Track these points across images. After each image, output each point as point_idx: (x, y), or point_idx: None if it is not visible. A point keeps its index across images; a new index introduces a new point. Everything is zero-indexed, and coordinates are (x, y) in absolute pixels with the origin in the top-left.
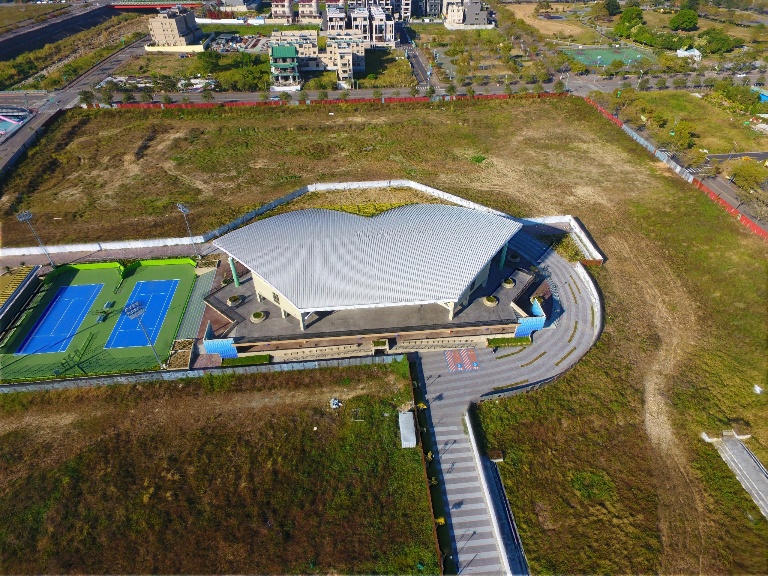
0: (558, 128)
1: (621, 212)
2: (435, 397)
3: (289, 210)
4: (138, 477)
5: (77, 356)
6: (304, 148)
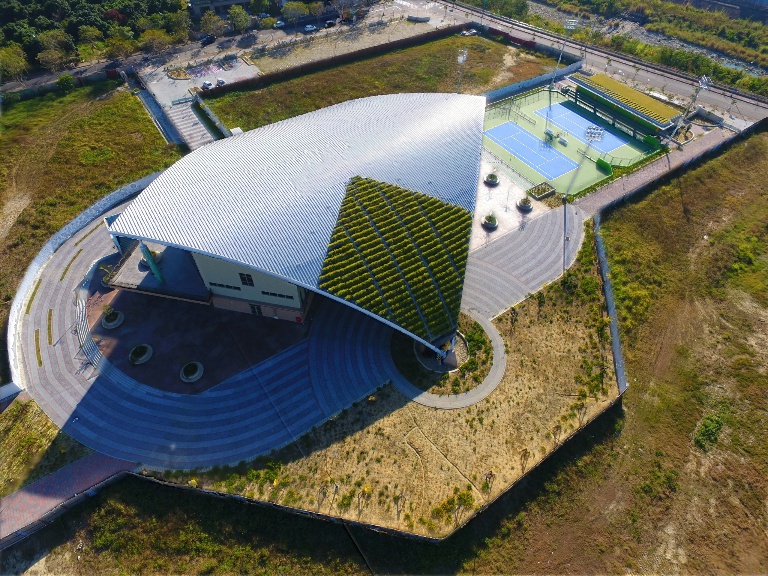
0: None
1: None
2: None
3: (579, 319)
4: (392, 88)
5: None
6: None
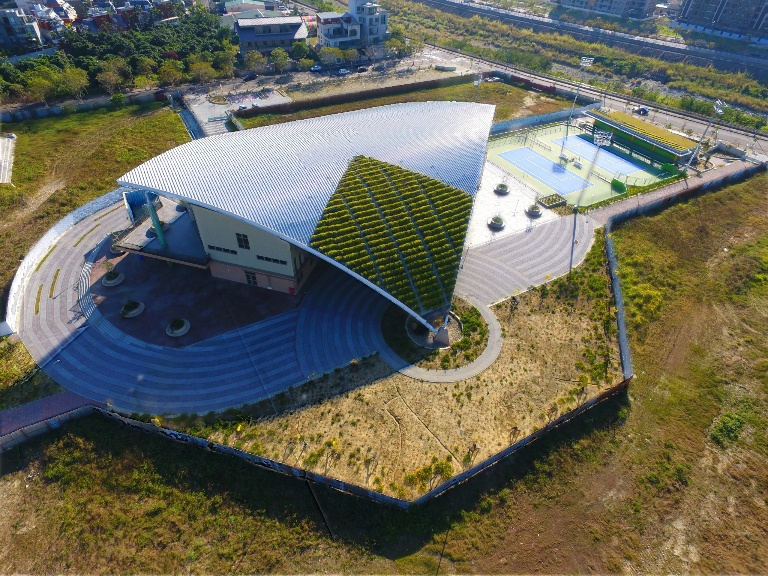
0: None
1: None
2: None
3: (584, 312)
4: None
5: None
6: None
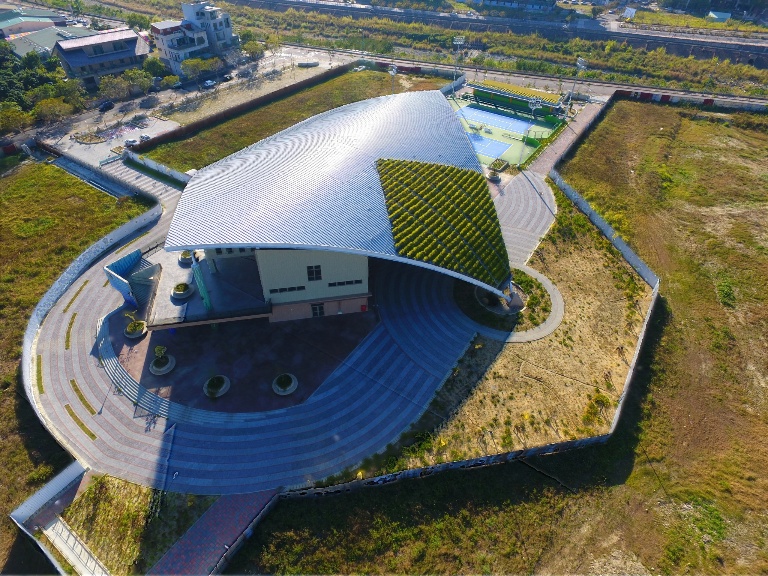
0: None
1: None
2: None
3: (589, 245)
4: None
5: None
6: None
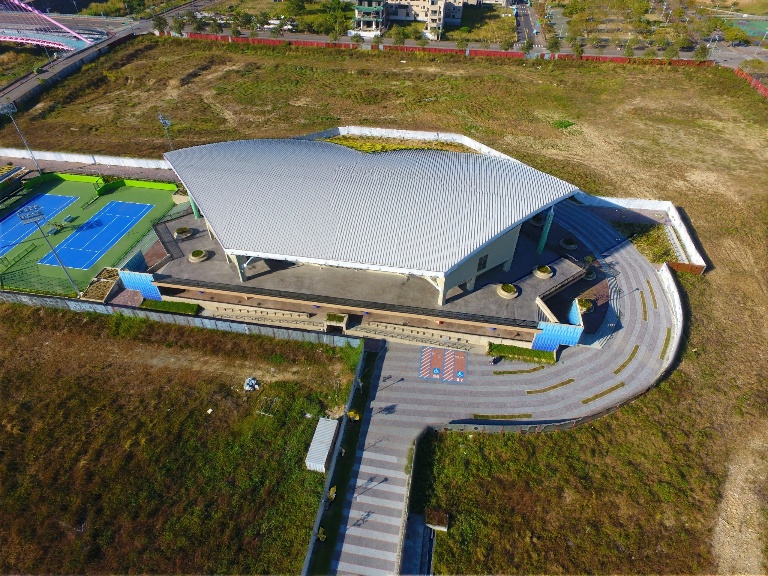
0: (686, 101)
1: (753, 210)
2: (384, 407)
3: None
4: None
5: (4, 265)
6: (357, 92)
